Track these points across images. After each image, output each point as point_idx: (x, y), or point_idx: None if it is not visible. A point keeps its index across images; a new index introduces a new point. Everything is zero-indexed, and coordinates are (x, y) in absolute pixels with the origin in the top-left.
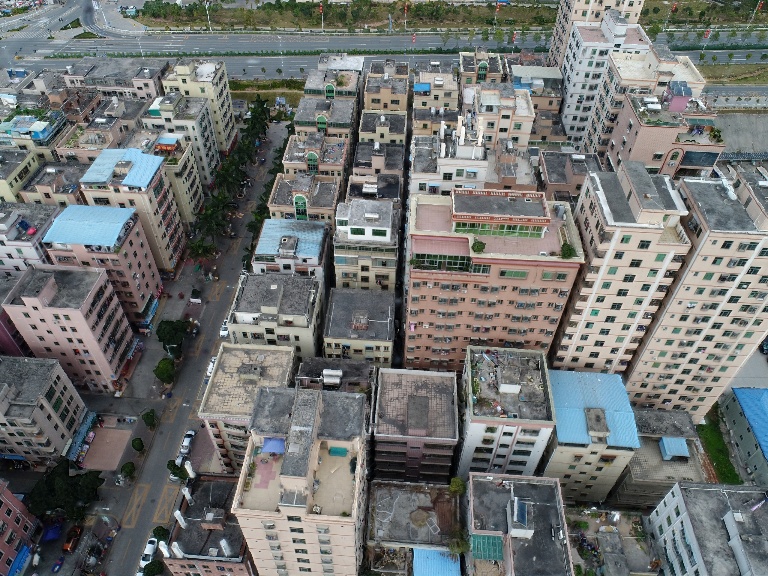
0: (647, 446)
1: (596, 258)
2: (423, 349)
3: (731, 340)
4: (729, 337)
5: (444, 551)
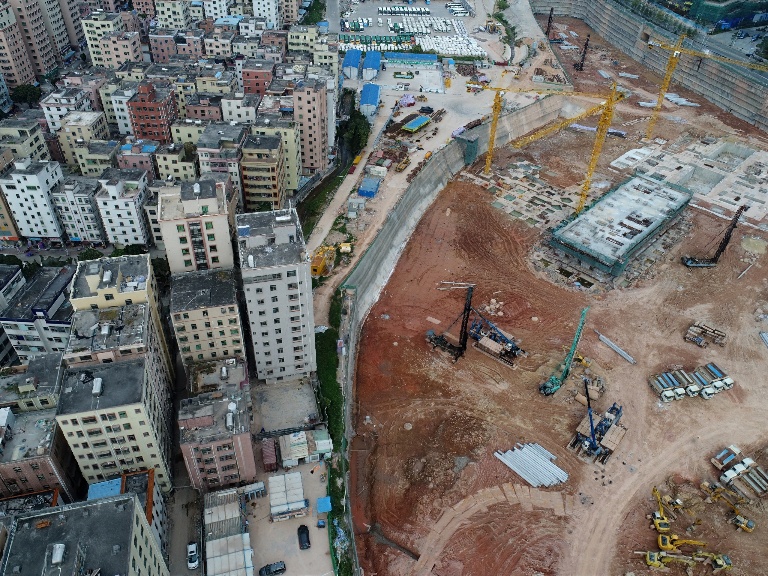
0: None
1: None
2: None
3: None
4: None
5: (200, 1)
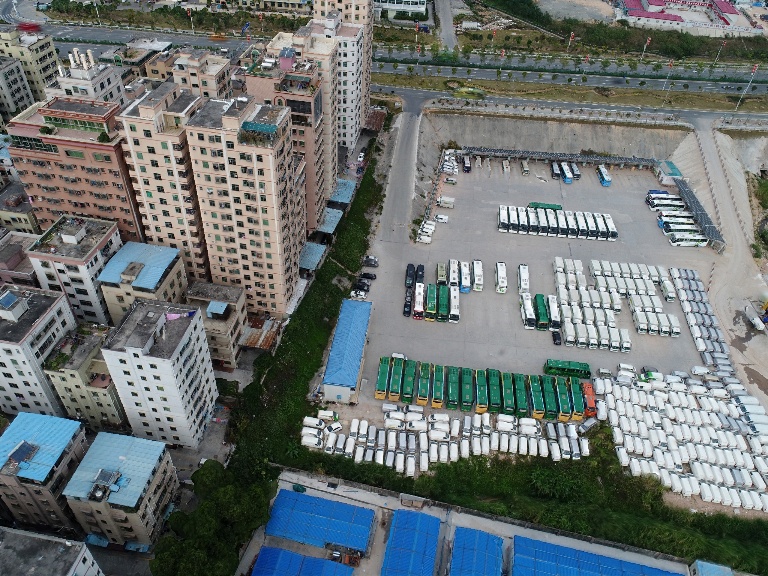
0: (204, 309)
1: (123, 144)
2: (50, 222)
3: (256, 226)
4: (253, 223)
5: None
